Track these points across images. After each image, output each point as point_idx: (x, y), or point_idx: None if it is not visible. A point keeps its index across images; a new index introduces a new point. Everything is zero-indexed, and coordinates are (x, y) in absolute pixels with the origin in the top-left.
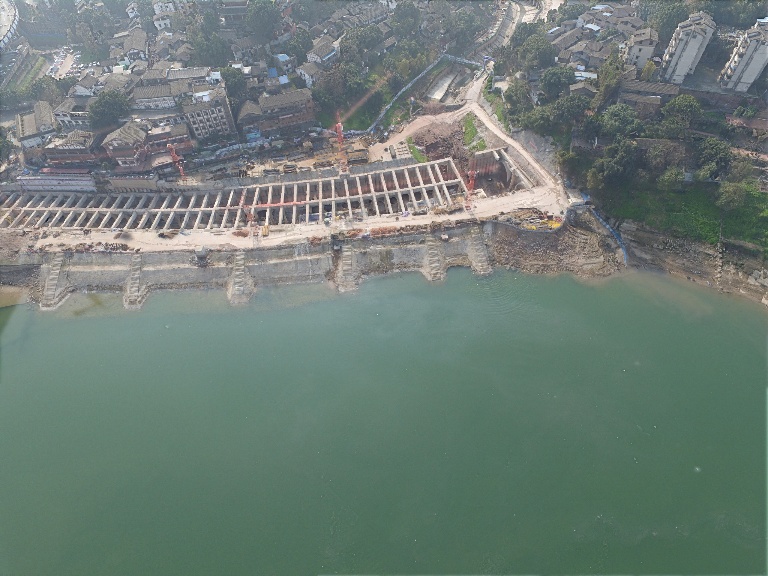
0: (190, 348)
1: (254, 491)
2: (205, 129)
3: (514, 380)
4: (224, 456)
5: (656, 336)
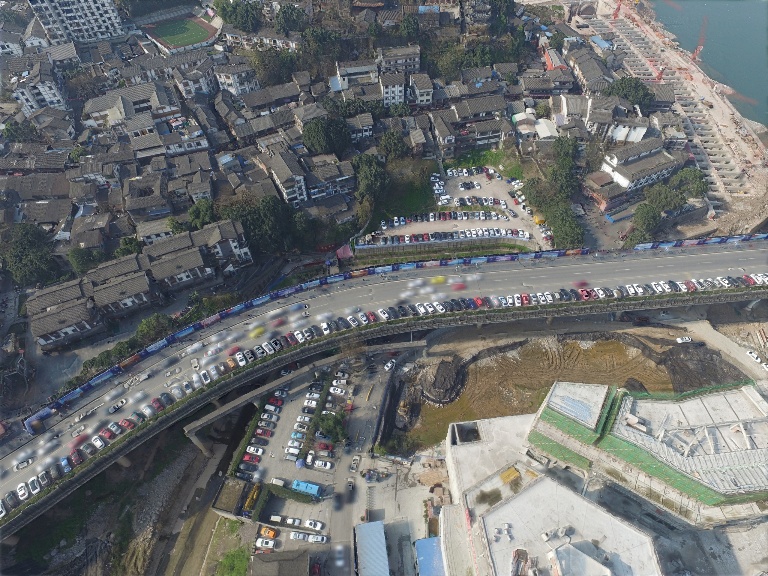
0: None
1: None
2: None
3: None
4: None
5: None
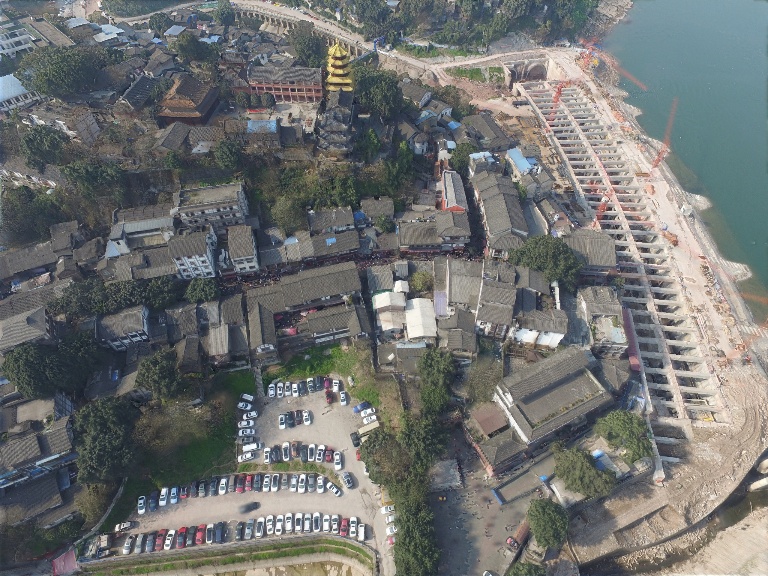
0: (765, 225)
1: None
2: None
3: None
4: None
5: (652, 52)
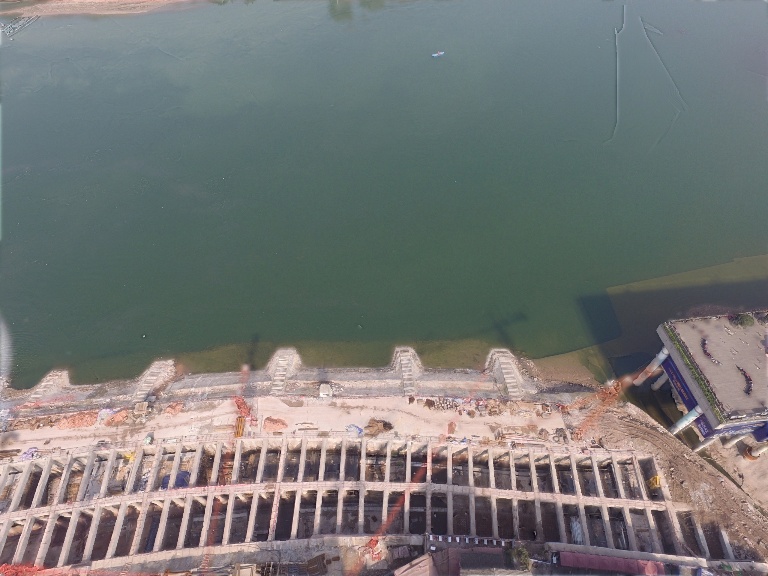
0: (331, 305)
1: (271, 217)
2: None
3: (57, 273)
4: (292, 232)
5: None
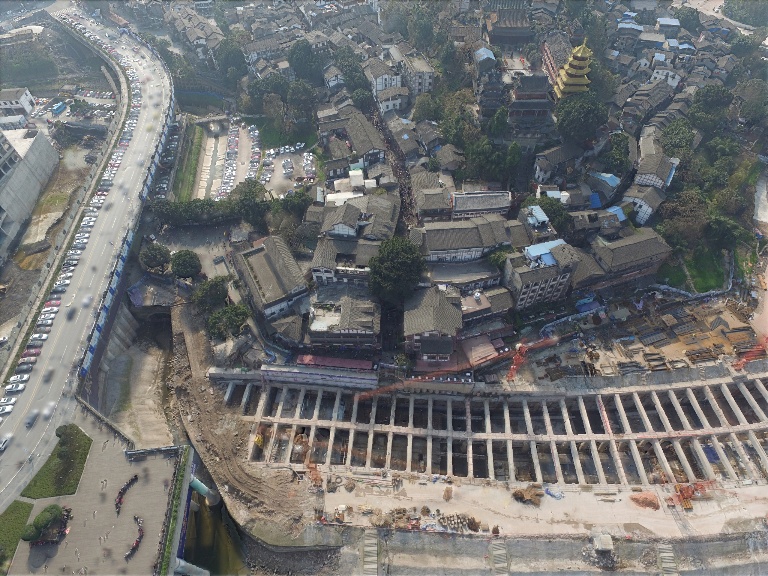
0: None
1: None
2: (532, 298)
3: None
4: None
5: None
